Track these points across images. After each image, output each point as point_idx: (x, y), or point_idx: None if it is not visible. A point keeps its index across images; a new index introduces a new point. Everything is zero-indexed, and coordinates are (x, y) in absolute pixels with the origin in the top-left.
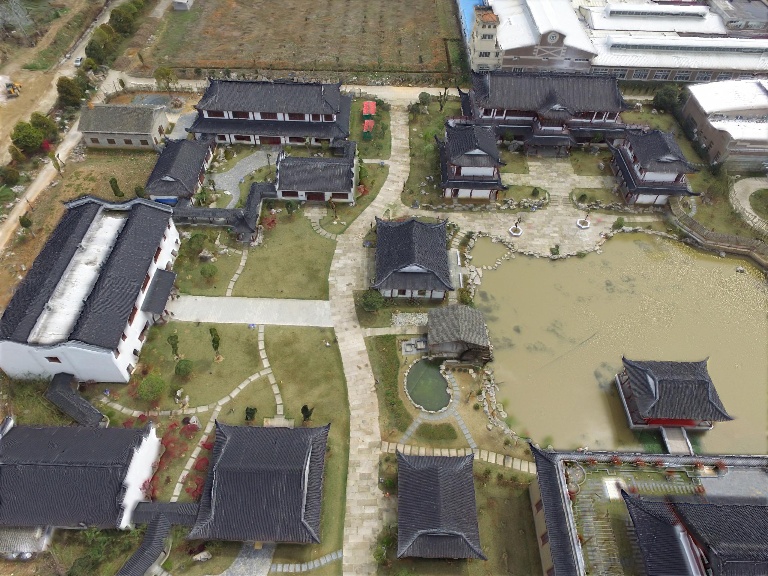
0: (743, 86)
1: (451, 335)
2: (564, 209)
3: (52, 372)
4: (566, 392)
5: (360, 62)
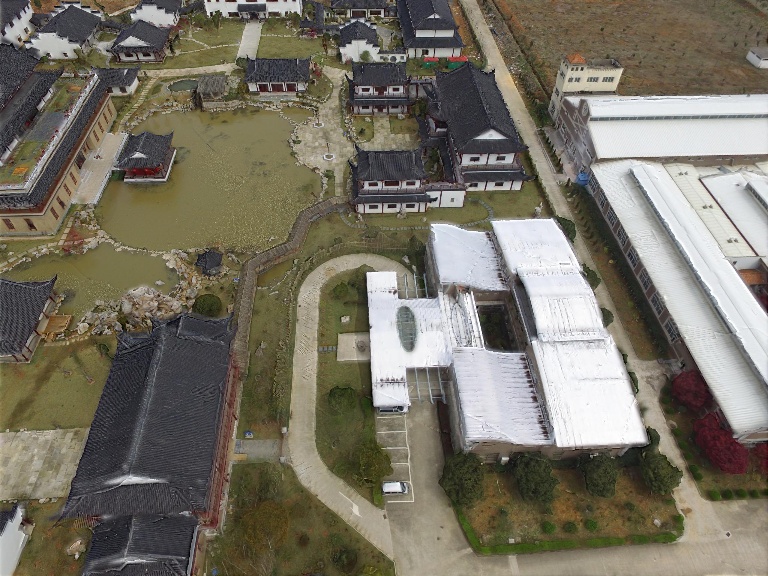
0: (553, 248)
1: (204, 76)
2: (349, 151)
3: None
4: (175, 139)
5: (543, 58)
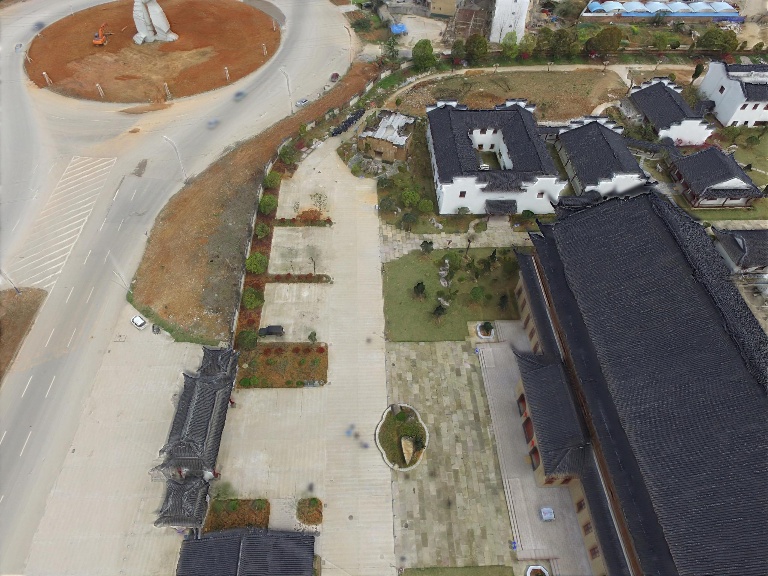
0: None
1: None
2: None
3: (712, 98)
4: None
5: None
